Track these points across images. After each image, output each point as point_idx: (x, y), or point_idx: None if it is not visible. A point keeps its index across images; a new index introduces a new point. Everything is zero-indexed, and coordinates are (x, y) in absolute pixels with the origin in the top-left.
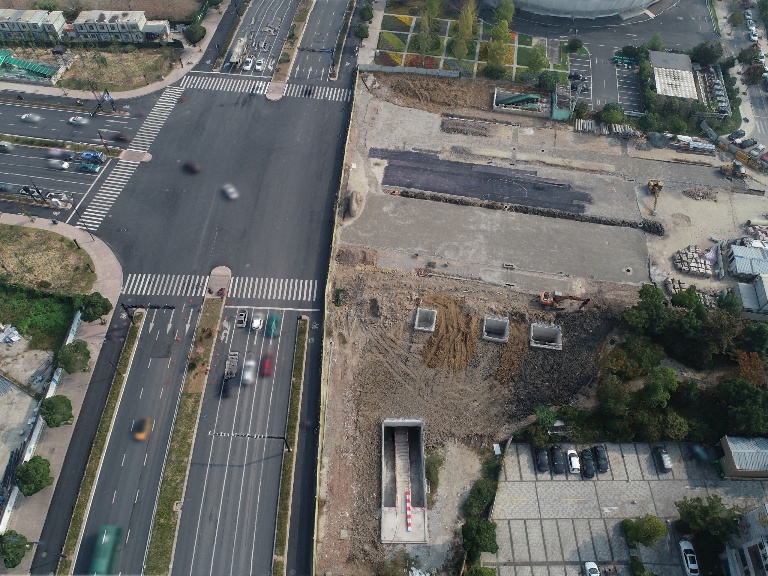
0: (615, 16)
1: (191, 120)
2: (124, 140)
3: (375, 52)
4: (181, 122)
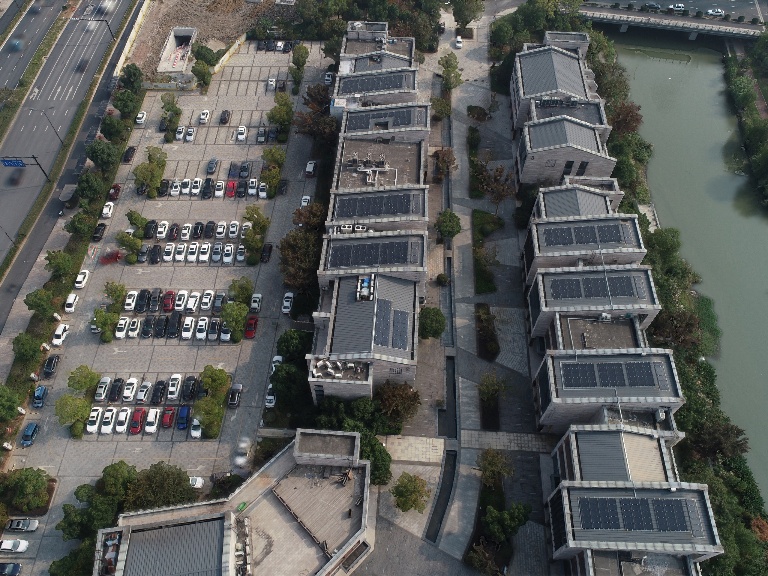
0: None
1: None
2: None
3: None
4: None
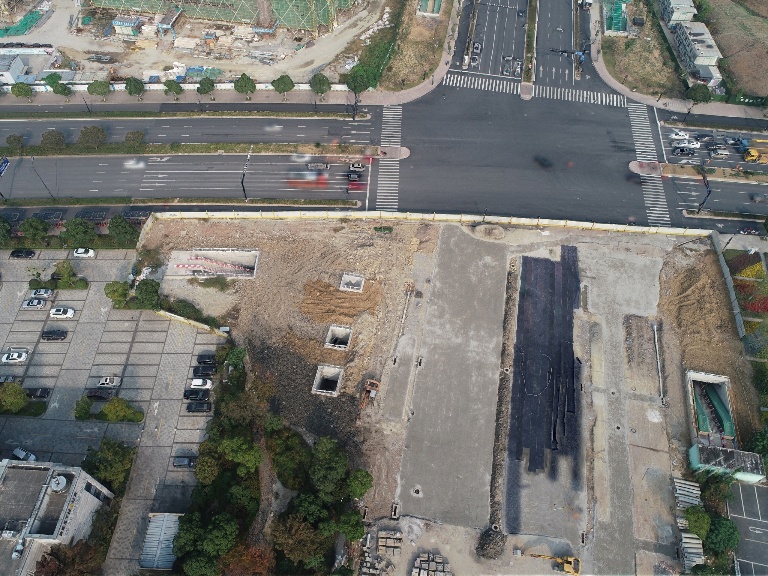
0: None
1: (581, 116)
2: (544, 82)
3: (755, 250)
4: (577, 110)
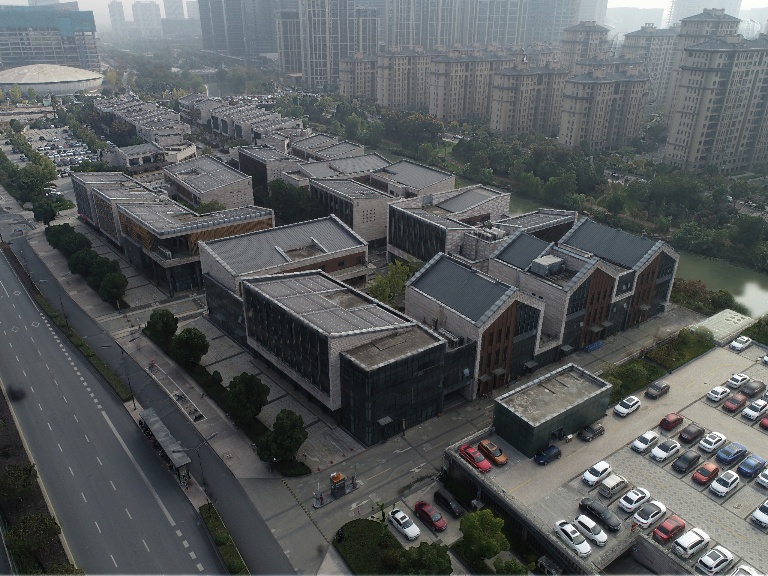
0: (72, 95)
1: None
2: None
3: None
4: None
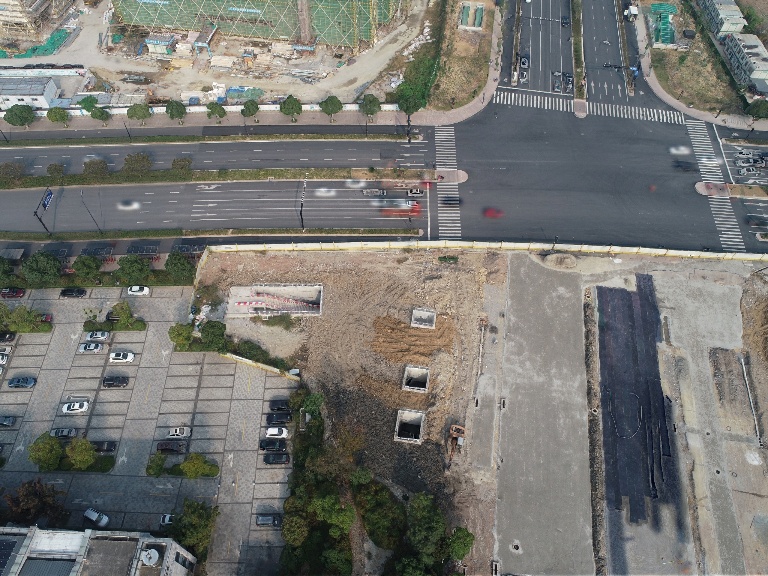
0: None
1: (640, 134)
2: (598, 98)
3: None
4: (634, 128)
